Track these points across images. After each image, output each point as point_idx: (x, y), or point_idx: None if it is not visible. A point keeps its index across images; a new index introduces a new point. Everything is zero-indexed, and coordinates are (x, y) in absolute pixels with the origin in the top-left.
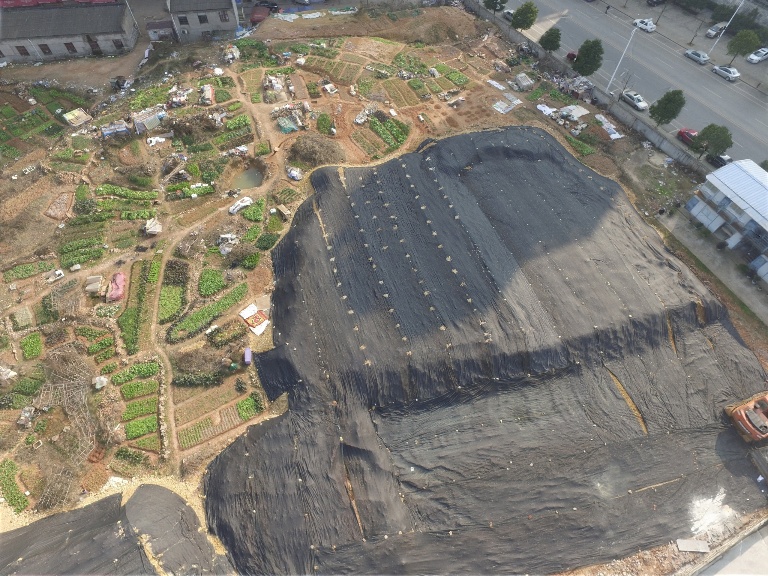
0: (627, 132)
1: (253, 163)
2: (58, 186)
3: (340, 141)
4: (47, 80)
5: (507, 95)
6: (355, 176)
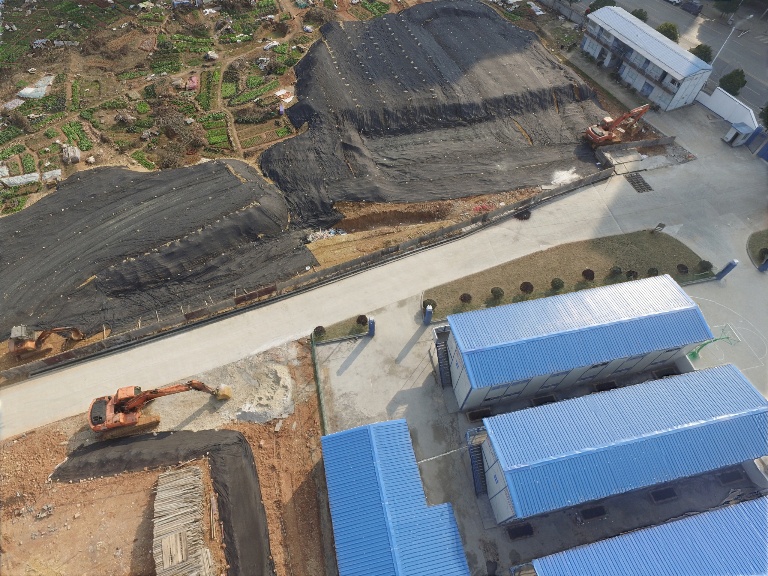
0: (548, 11)
1: (278, 27)
2: (145, 34)
3: (340, 13)
4: None
5: None
6: (350, 24)
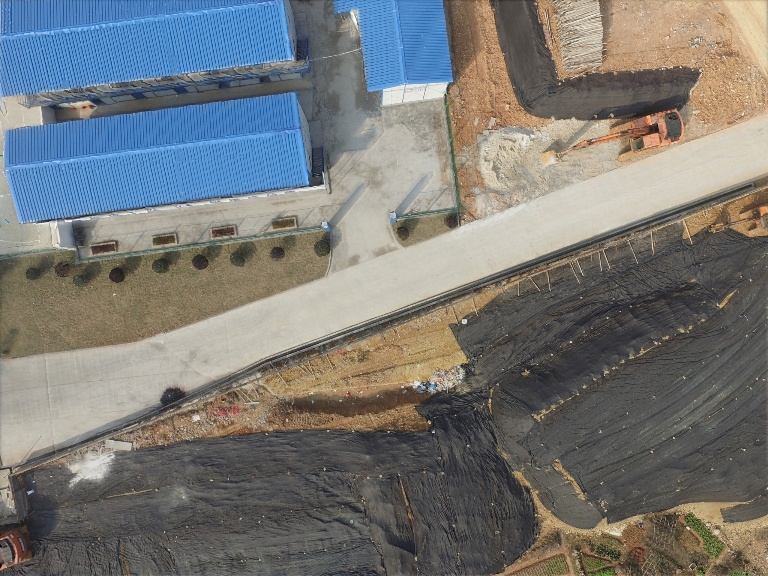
0: None
1: None
2: None
3: None
4: None
5: None
6: None
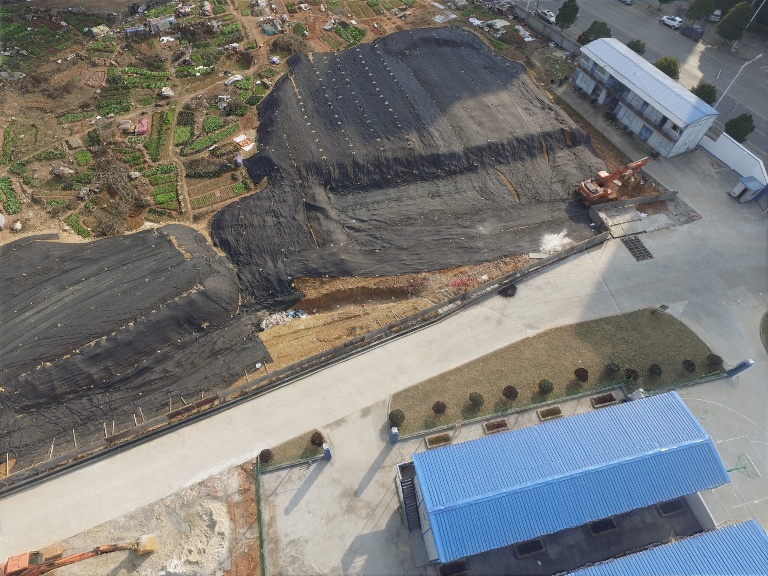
0: (538, 36)
1: (243, 56)
2: (93, 67)
3: (311, 41)
4: (75, 8)
5: (446, 12)
6: (320, 56)
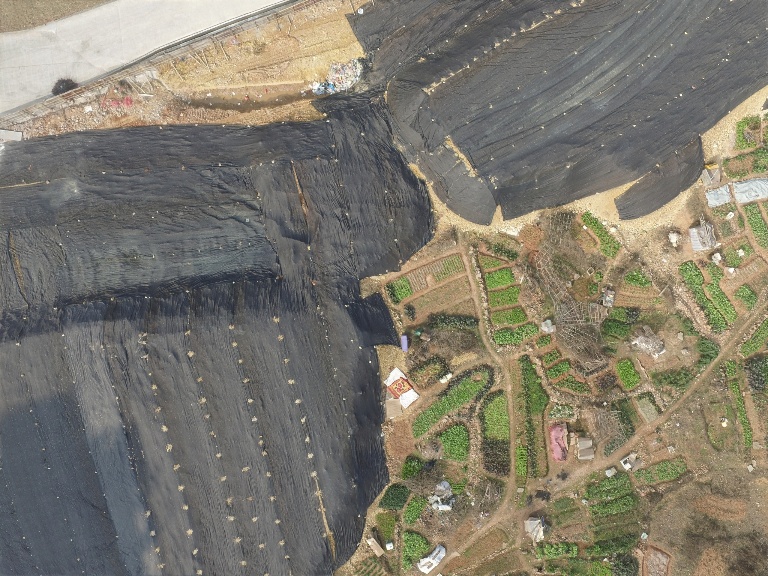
0: None
1: None
2: None
3: None
4: None
5: None
6: None
